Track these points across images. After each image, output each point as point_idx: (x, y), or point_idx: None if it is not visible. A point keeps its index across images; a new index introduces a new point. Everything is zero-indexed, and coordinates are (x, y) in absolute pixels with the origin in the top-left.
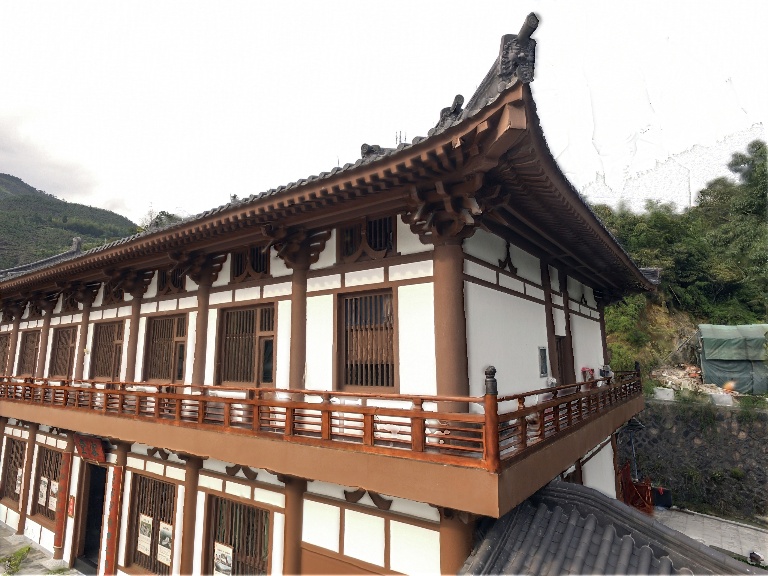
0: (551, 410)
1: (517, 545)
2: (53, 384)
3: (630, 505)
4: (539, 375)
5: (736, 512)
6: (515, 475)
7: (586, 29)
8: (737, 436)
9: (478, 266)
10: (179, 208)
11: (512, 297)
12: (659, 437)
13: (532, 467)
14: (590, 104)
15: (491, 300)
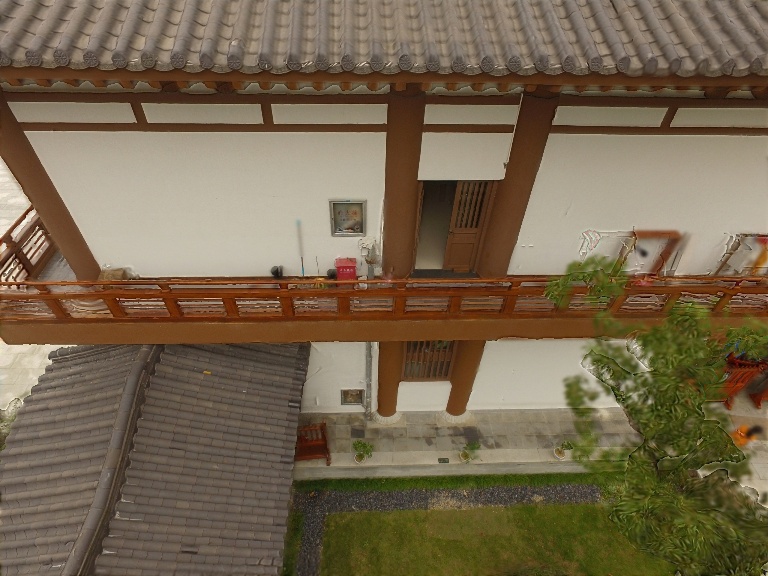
0: None
1: (118, 357)
2: None
3: None
4: (330, 233)
5: None
6: (31, 330)
7: None
8: None
9: (61, 106)
10: None
11: (206, 135)
12: None
13: (77, 331)
14: None
15: (124, 147)
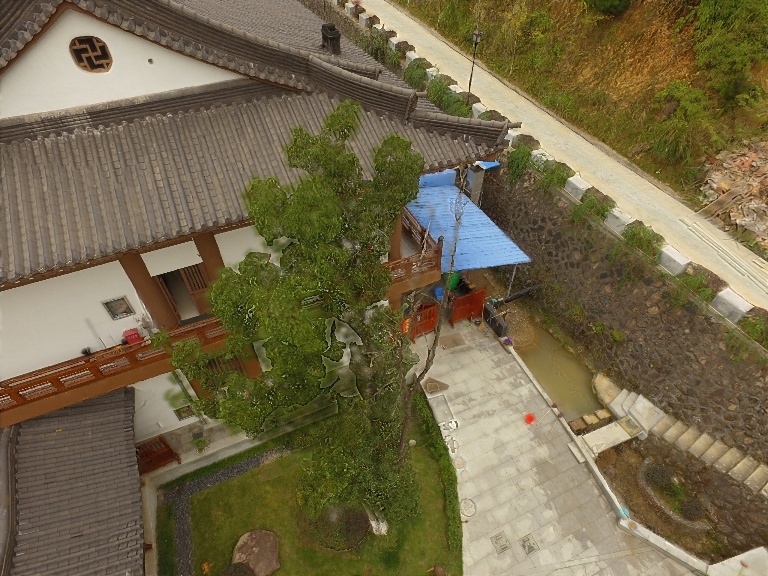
0: (1, 396)
1: None
2: None
3: (466, 319)
4: (112, 319)
5: (589, 361)
6: None
7: None
8: (648, 308)
9: None
10: None
11: (3, 293)
12: (578, 264)
13: None
14: None
15: None
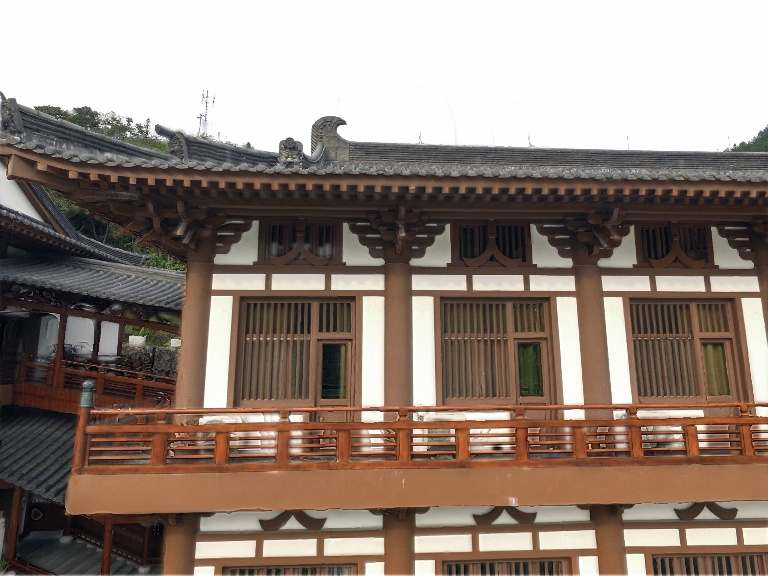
0: None
1: None
2: (674, 415)
3: None
4: None
5: None
6: None
7: (455, 68)
8: None
9: None
10: None
11: None
12: None
13: None
14: (454, 134)
15: None
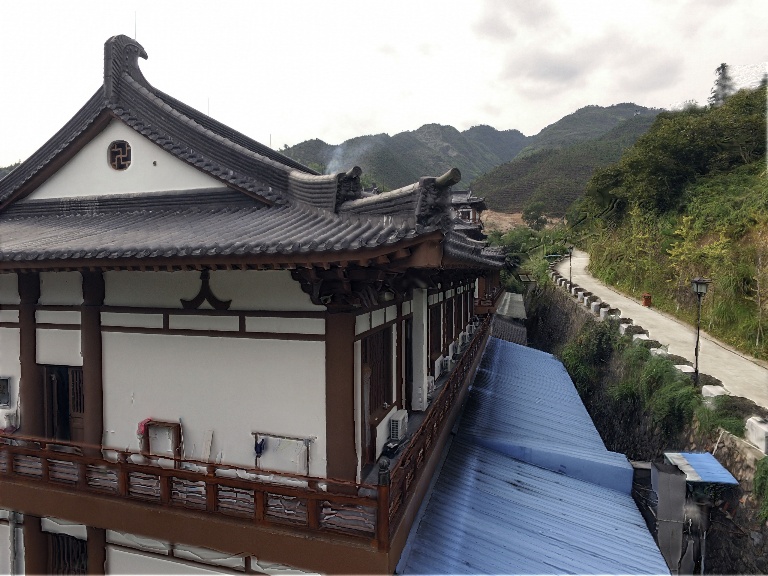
0: None
1: None
2: None
3: None
4: None
5: None
6: None
7: None
8: None
9: None
10: (673, 104)
11: None
12: None
13: None
14: None
15: None
